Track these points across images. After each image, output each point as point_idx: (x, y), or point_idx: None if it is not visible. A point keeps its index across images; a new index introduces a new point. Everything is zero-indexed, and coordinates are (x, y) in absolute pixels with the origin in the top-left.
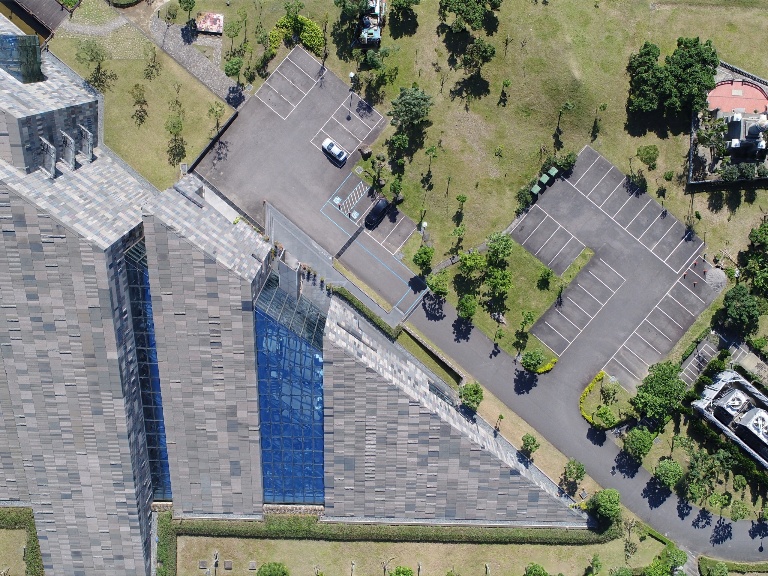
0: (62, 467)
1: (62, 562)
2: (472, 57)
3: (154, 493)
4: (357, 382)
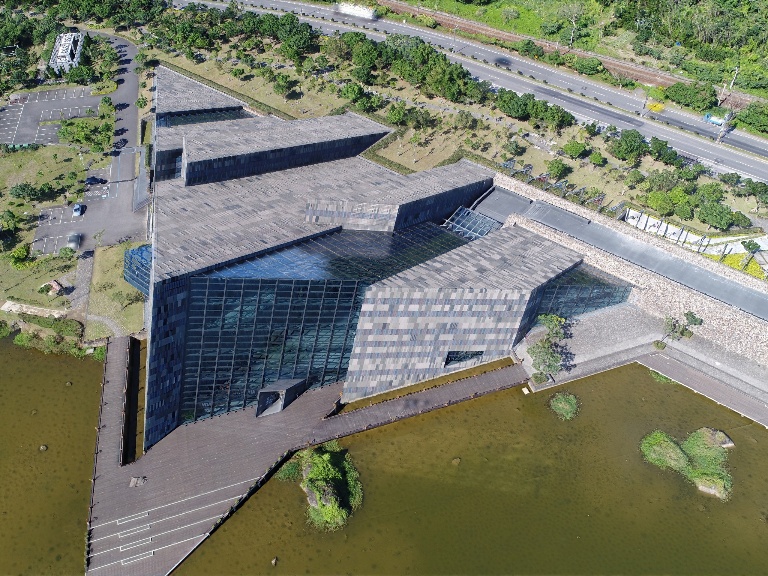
0: (316, 133)
1: None
2: None
3: None
4: None
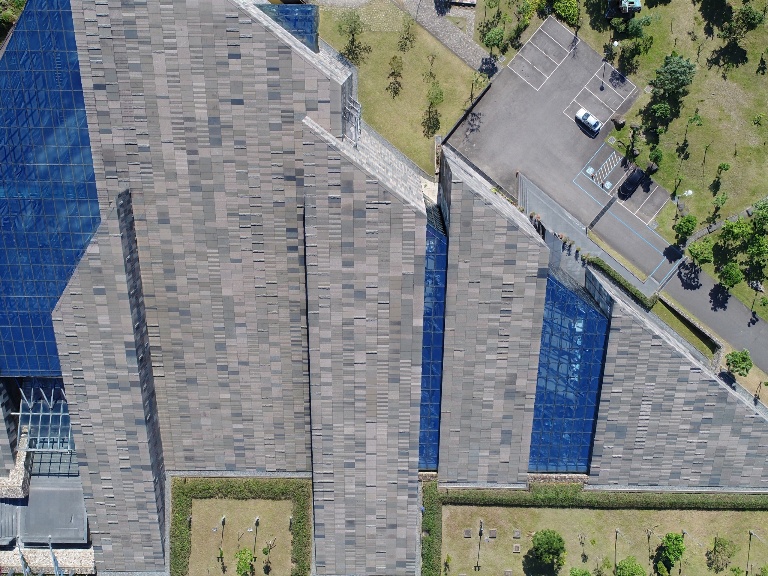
0: (350, 436)
1: (334, 531)
2: (738, 24)
3: None
4: (641, 349)
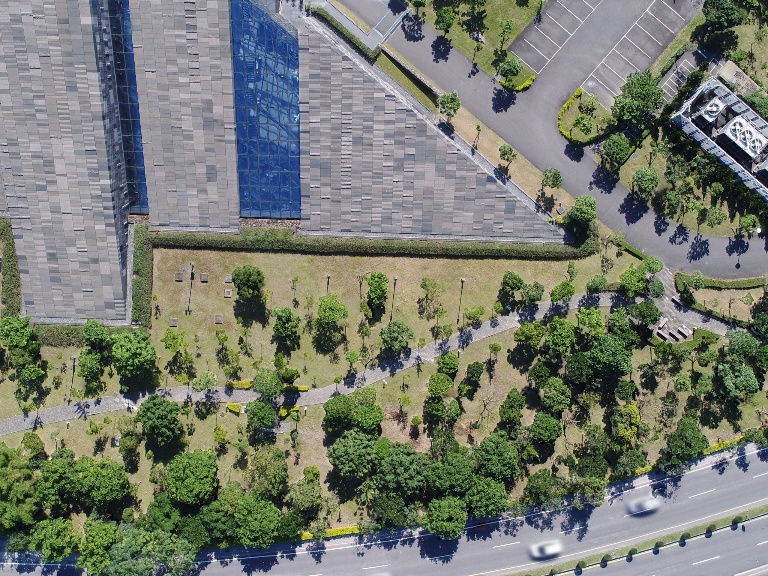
0: (37, 153)
1: (38, 266)
2: None
3: (131, 207)
4: (333, 72)
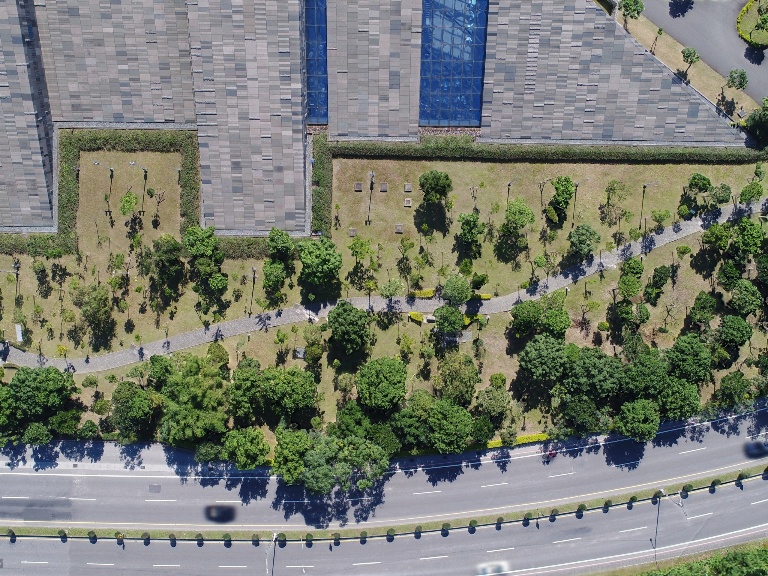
0: (230, 56)
1: (221, 176)
2: None
3: (308, 118)
4: None
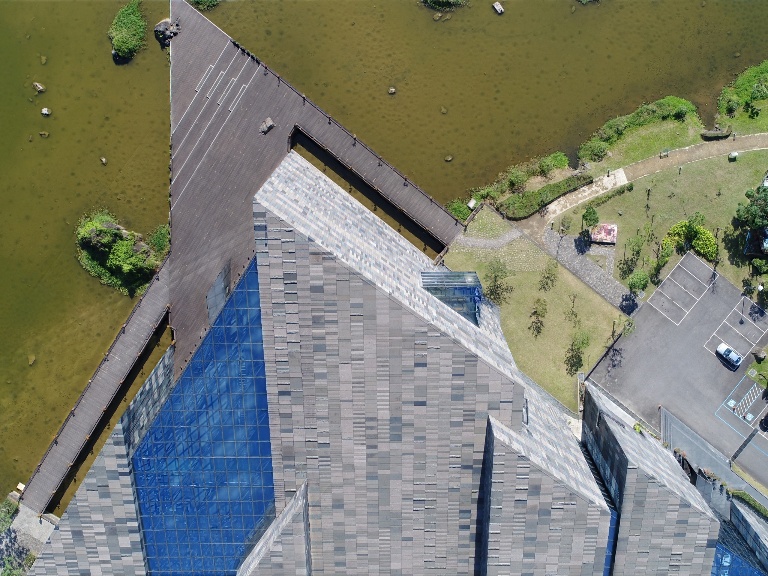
0: None
1: None
2: None
3: None
4: None
